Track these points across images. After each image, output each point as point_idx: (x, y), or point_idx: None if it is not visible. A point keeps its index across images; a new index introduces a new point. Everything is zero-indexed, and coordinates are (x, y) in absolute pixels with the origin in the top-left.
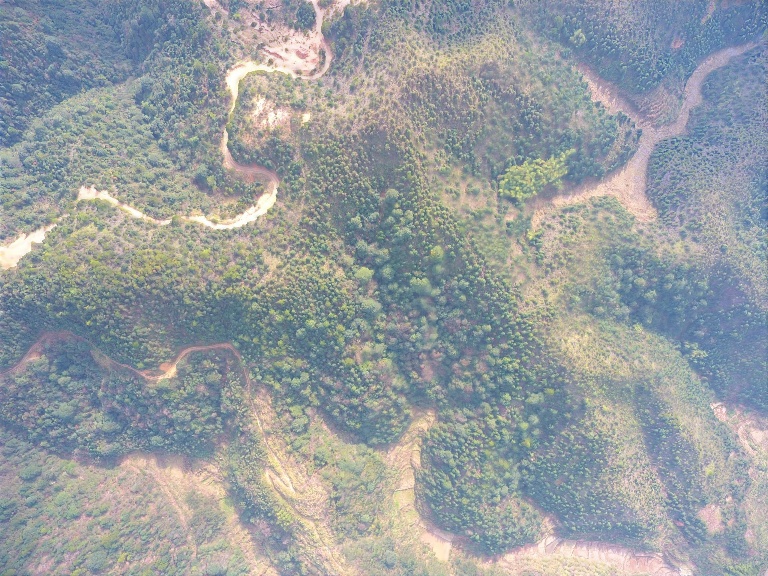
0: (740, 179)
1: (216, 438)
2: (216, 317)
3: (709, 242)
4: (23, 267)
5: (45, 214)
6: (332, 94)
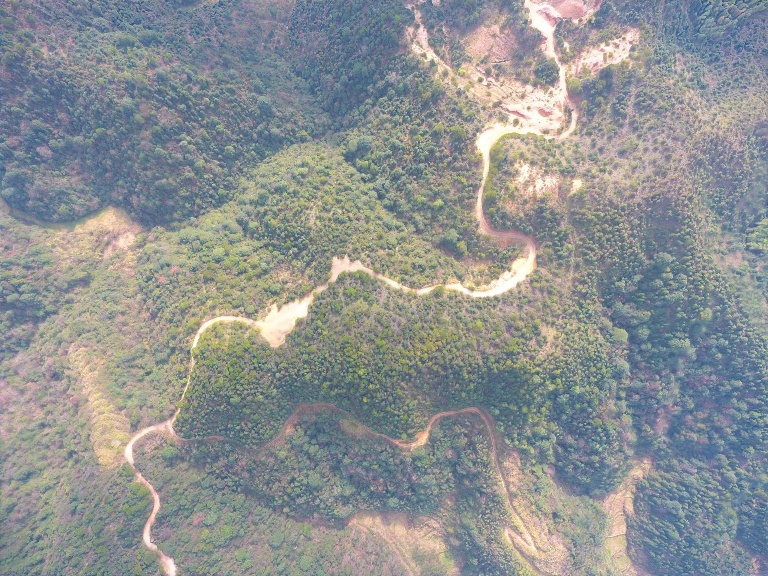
0: None
1: (444, 495)
2: (480, 386)
3: None
4: (296, 345)
5: (291, 284)
6: None
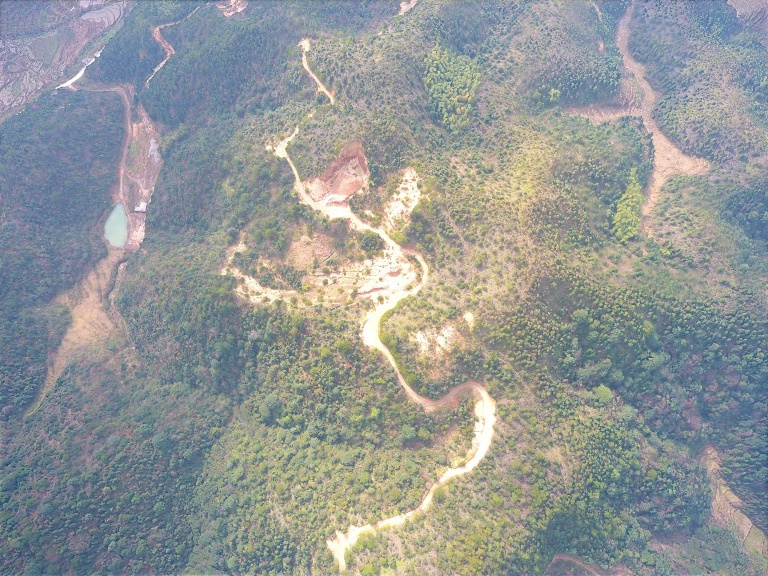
0: (735, 93)
1: None
2: None
3: (767, 149)
4: None
5: None
6: (464, 282)
